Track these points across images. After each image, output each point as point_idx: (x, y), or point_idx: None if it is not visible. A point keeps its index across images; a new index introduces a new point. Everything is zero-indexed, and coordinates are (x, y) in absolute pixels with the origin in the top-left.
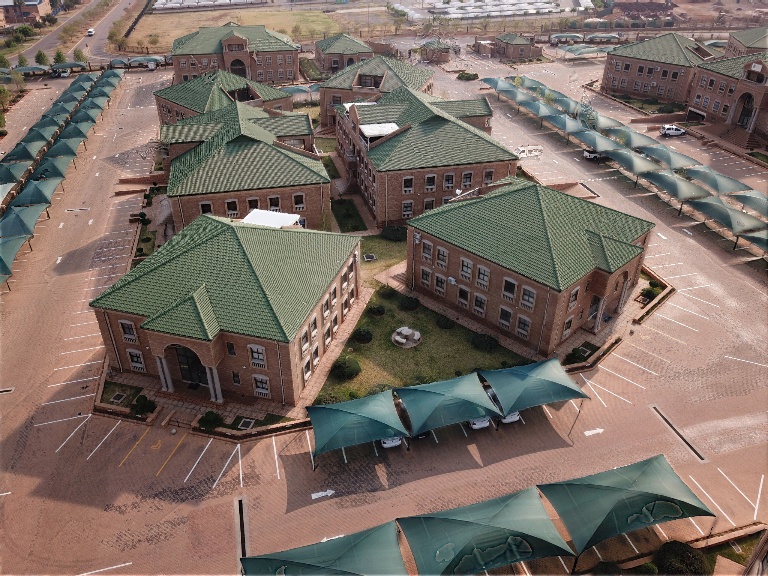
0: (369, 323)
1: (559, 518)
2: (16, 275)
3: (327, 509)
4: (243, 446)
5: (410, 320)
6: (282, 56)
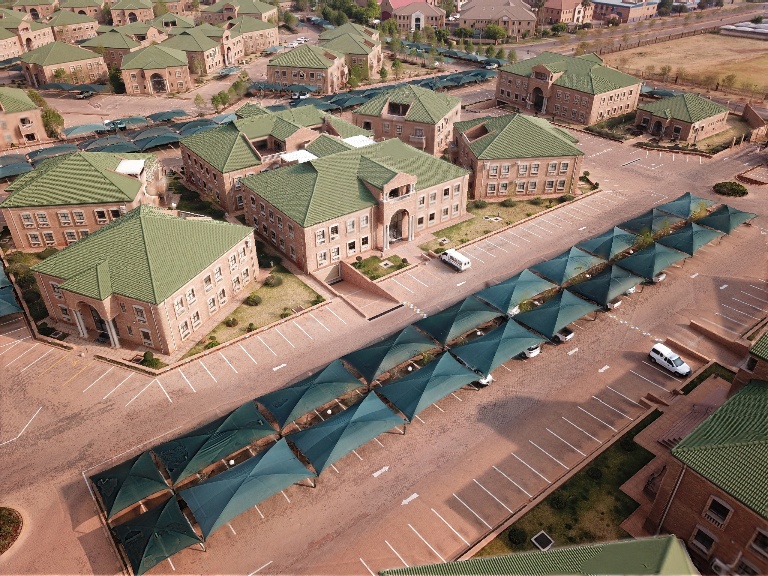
0: None
1: None
2: (159, 154)
3: None
4: None
5: None
6: (580, 96)
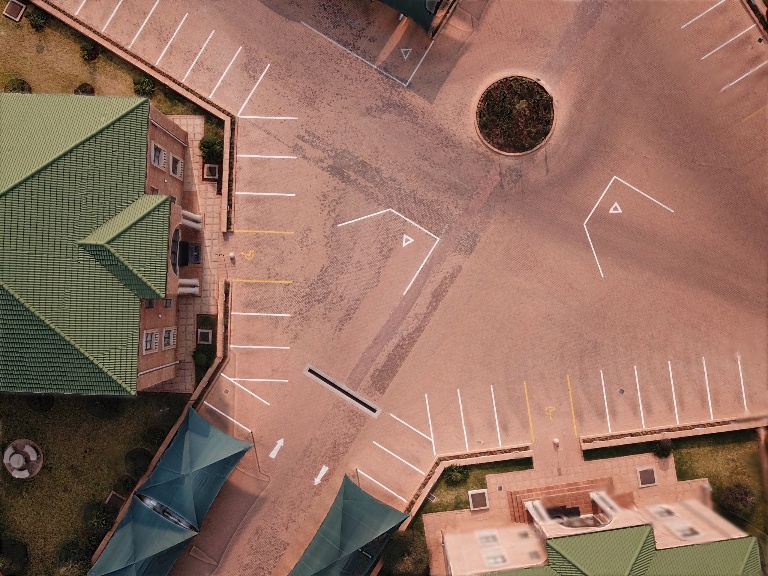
0: None
1: None
2: None
3: None
4: None
5: (1, 425)
6: None
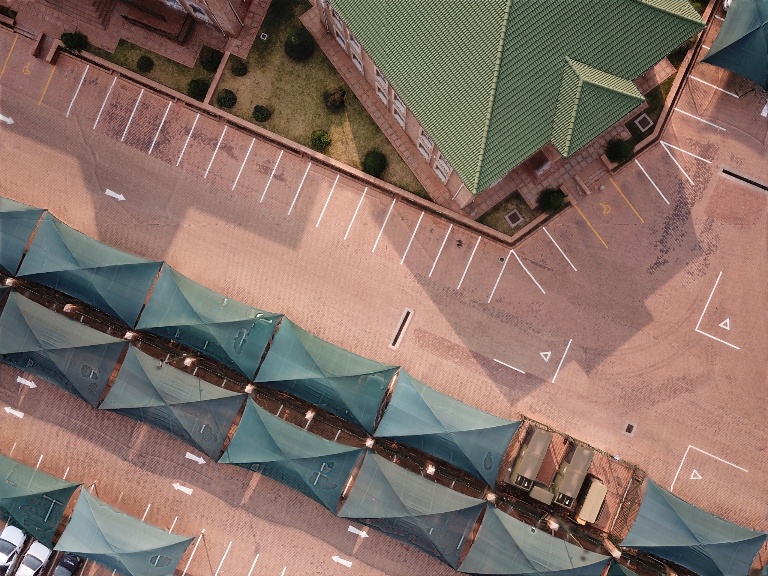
0: None
1: None
2: None
3: None
4: (666, 139)
5: None
6: None
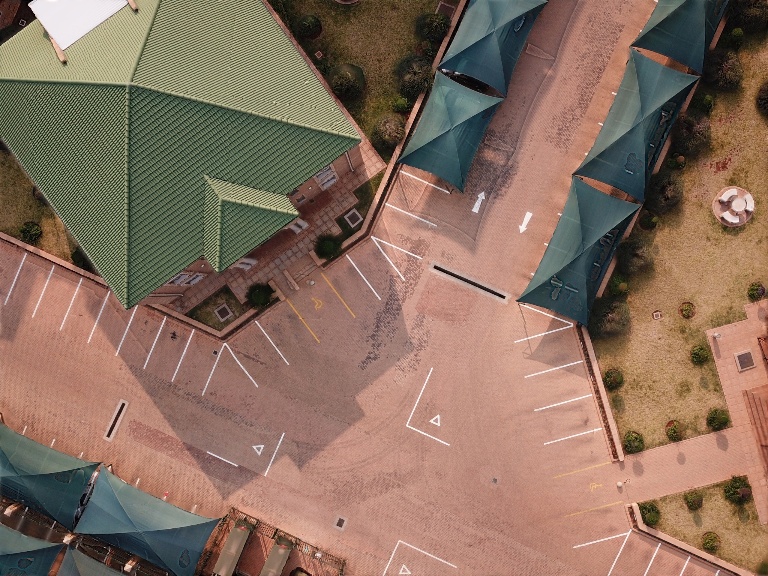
0: (289, 2)
1: (668, 58)
2: None
3: (496, 208)
4: (377, 234)
5: None
6: None
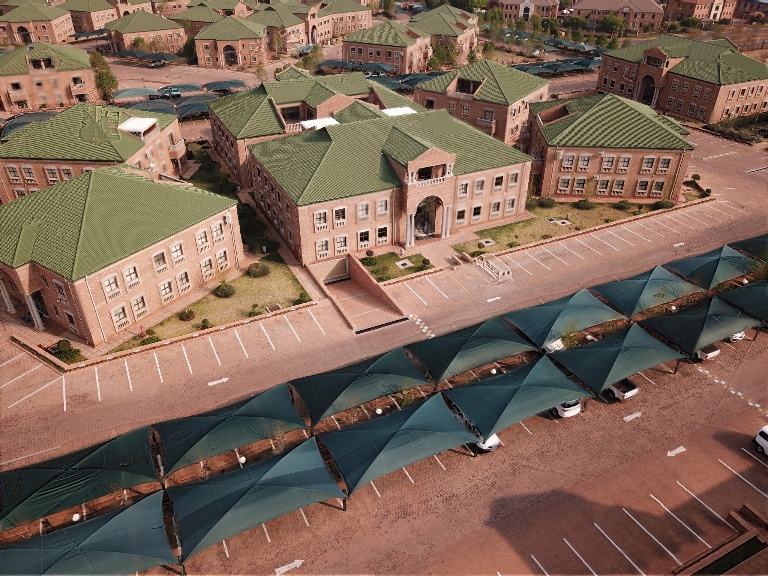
0: None
1: None
2: (200, 123)
3: None
4: None
5: None
6: (701, 87)
